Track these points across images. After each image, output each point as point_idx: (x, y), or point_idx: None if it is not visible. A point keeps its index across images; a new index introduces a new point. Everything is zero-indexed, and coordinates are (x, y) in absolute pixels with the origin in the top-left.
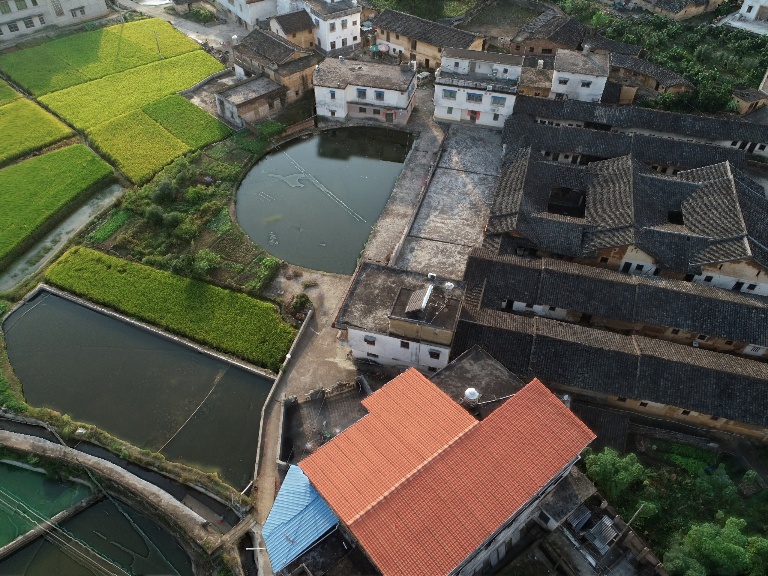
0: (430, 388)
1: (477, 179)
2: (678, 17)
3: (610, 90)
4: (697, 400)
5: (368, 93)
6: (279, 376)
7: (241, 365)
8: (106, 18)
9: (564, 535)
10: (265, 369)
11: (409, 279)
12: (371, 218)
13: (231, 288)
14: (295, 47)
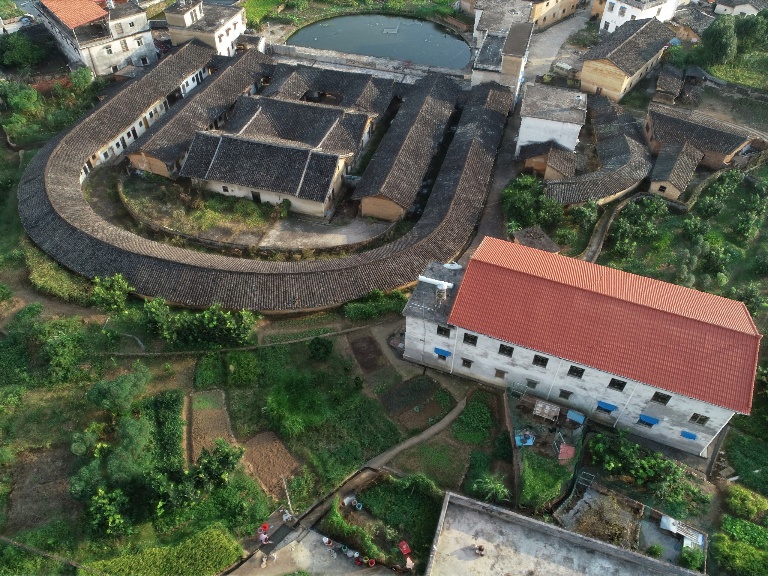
0: None
1: None
2: None
3: (539, 148)
4: None
5: None
6: None
7: None
8: None
9: None
10: None
11: (225, 18)
12: (336, 48)
13: None
14: None
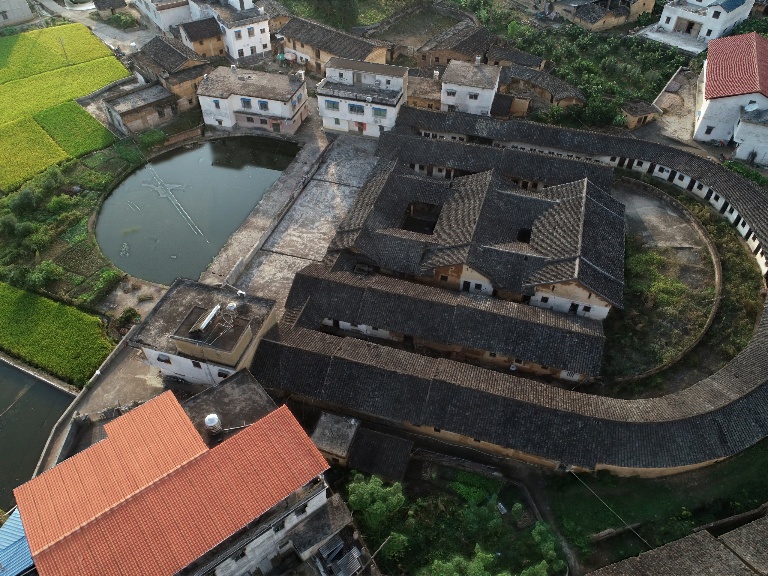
0: (177, 413)
1: (348, 192)
2: (596, 27)
3: (501, 102)
4: (481, 428)
5: (253, 103)
6: (81, 393)
7: (46, 381)
8: (29, 23)
9: (315, 566)
10: (71, 385)
11: (219, 296)
12: (227, 231)
13: (63, 301)
14: (191, 55)
